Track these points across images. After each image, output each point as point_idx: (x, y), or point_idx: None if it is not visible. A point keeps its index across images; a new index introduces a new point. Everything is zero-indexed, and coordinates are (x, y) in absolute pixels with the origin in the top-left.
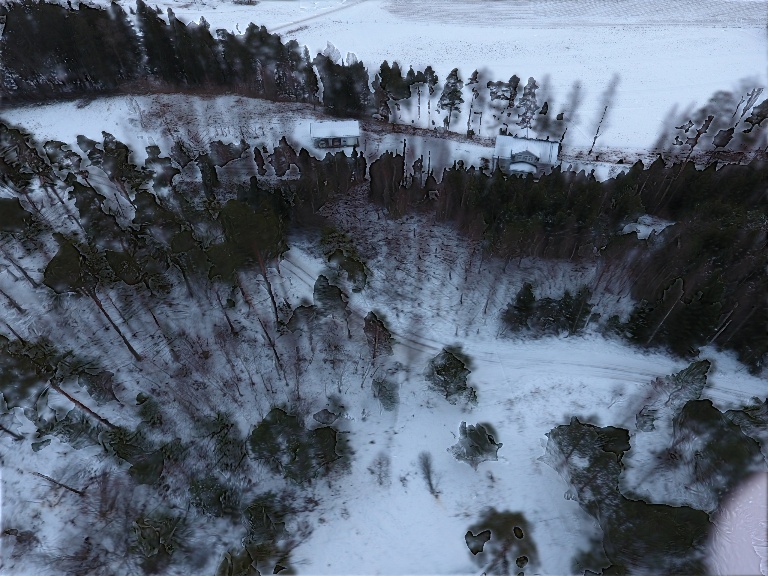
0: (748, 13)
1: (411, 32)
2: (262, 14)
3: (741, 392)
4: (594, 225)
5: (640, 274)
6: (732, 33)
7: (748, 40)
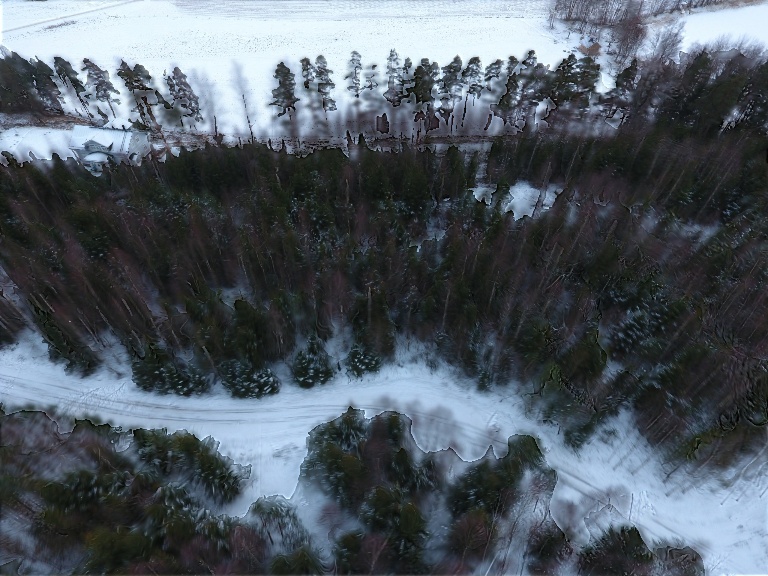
0: (541, 3)
1: (187, 26)
2: (35, 10)
3: (15, 378)
4: (16, 213)
5: (0, 261)
6: (510, 23)
7: (519, 29)
